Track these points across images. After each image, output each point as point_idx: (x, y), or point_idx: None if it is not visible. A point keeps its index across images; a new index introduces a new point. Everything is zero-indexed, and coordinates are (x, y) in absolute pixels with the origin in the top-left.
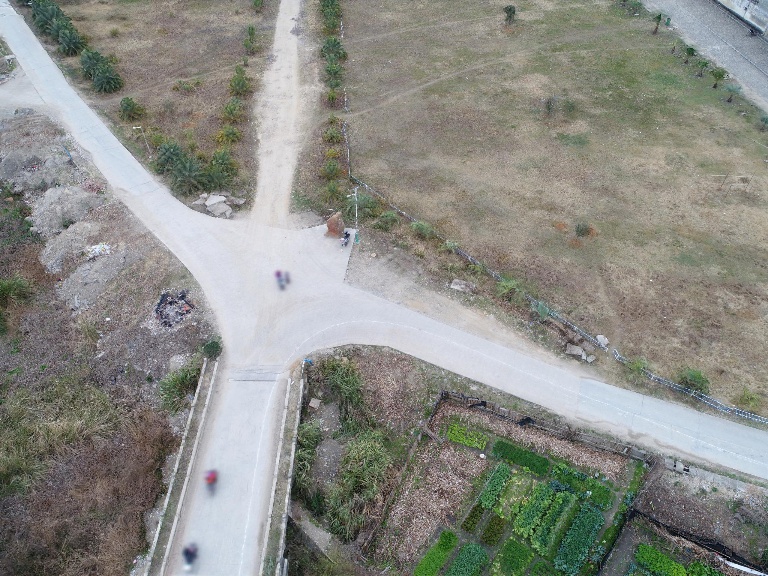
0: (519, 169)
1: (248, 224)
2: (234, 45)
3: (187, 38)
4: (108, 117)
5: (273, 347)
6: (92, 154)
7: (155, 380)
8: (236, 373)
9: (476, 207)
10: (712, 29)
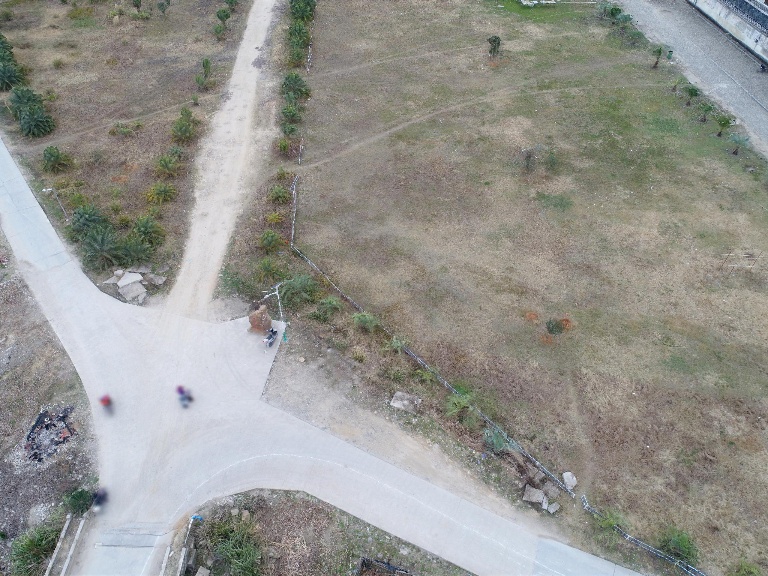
0: (489, 239)
1: (161, 313)
2: (187, 79)
3: (137, 70)
4: (30, 168)
5: (159, 494)
6: (2, 216)
7: (10, 537)
8: (106, 534)
9: (434, 289)
10: (719, 63)
